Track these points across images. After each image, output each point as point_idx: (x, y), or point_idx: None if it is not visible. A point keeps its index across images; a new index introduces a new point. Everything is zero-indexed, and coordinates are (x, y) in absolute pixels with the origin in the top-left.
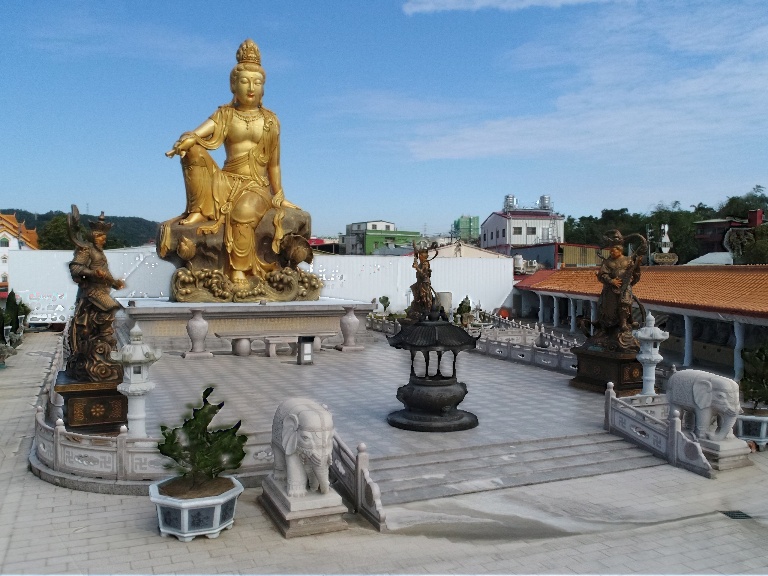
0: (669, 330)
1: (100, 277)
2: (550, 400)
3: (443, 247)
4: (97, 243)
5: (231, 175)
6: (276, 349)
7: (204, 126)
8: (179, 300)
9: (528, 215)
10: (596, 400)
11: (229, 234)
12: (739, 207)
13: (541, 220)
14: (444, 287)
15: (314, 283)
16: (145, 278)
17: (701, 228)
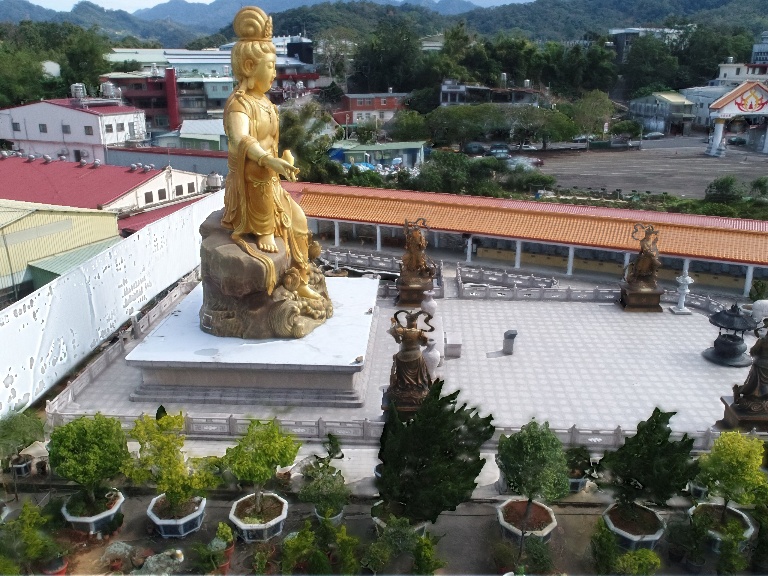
0: (492, 246)
1: None
2: (669, 325)
3: (157, 176)
4: None
5: None
6: None
7: (245, 124)
8: (301, 336)
9: (100, 107)
10: (670, 317)
11: None
12: (85, 46)
13: (127, 115)
14: None
15: None
16: (58, 318)
17: (116, 83)
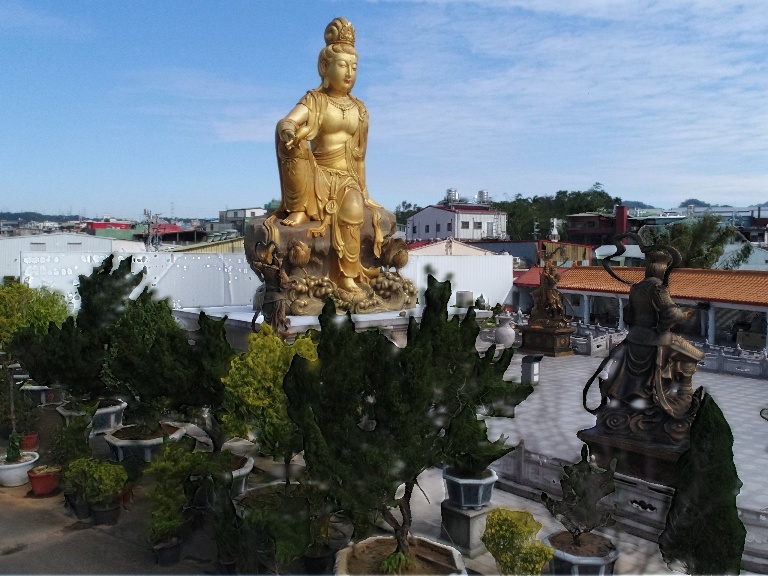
0: (759, 330)
1: (681, 320)
2: None
3: (434, 243)
4: None
5: (327, 169)
6: None
7: (298, 112)
8: (297, 313)
9: (469, 209)
10: None
11: (338, 237)
12: (582, 201)
13: (486, 215)
14: (457, 286)
15: (412, 289)
16: (177, 283)
17: (572, 221)
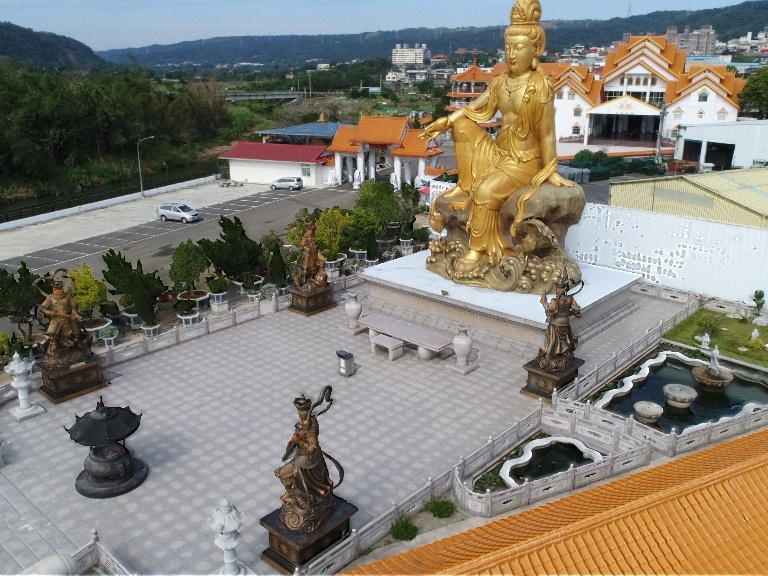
0: None
1: None
2: None
3: None
4: (54, 294)
5: (495, 149)
6: (379, 347)
7: (481, 96)
8: None
9: None
10: None
11: (471, 213)
12: None
13: None
14: None
15: (543, 276)
16: None
17: None
